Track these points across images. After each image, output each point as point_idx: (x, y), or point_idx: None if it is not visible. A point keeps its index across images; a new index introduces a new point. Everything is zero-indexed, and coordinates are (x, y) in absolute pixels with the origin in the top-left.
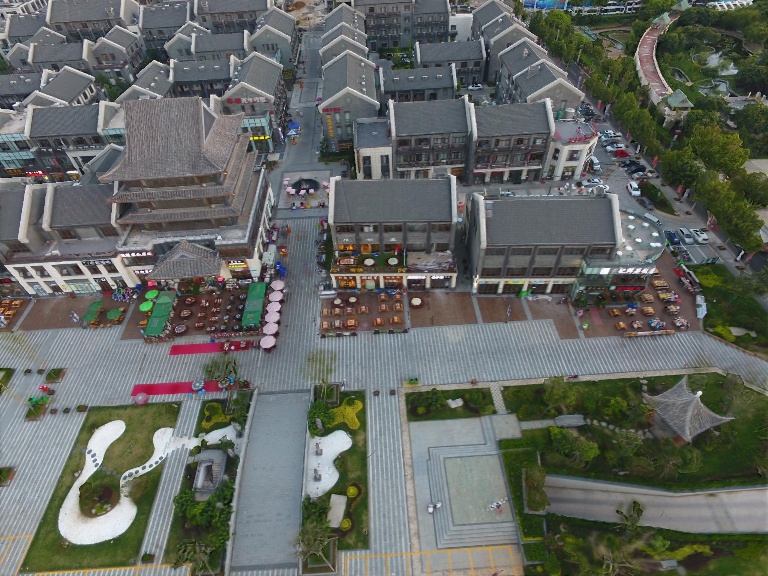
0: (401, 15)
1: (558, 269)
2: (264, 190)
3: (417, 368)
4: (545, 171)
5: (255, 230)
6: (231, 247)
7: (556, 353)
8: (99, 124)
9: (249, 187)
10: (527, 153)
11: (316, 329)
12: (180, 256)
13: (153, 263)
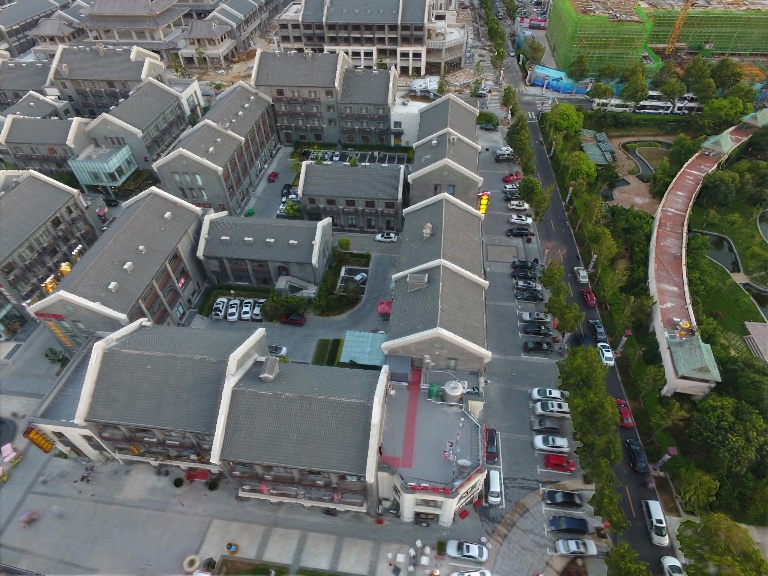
0: (322, 102)
1: None
2: None
3: None
4: (388, 498)
5: None
6: None
7: None
8: None
9: None
10: None
11: None
12: None
13: None
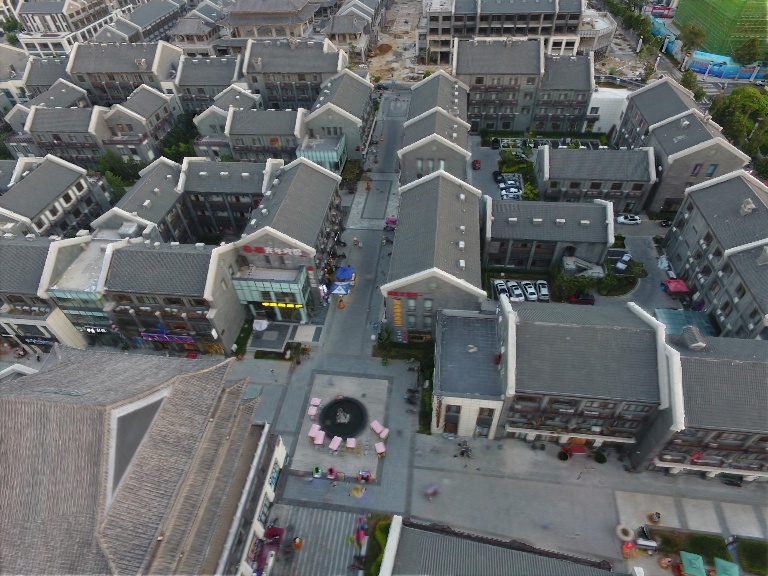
0: (521, 90)
1: None
2: (263, 468)
3: None
4: None
5: None
6: None
7: None
8: (42, 282)
9: None
10: None
11: None
12: None
13: None
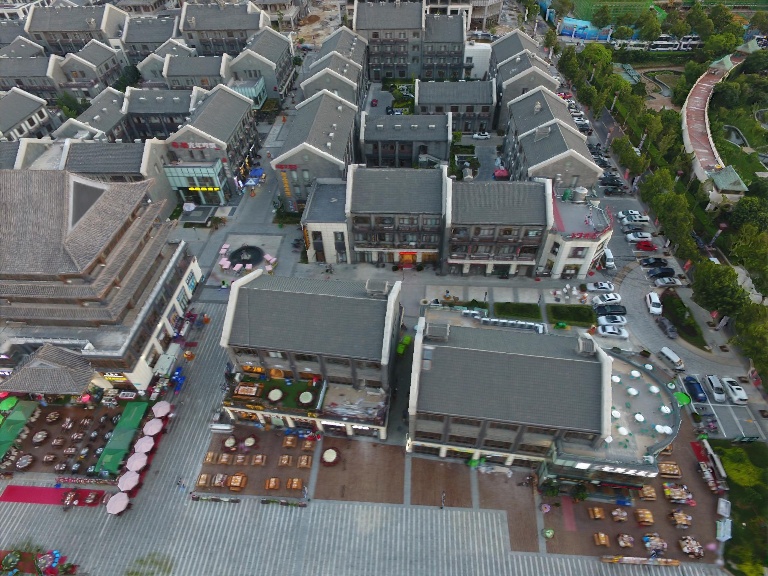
0: (409, 42)
1: (520, 445)
2: (181, 269)
3: (302, 573)
4: (541, 265)
5: (147, 331)
6: (103, 359)
7: (500, 575)
8: (16, 166)
9: (158, 267)
10: (516, 246)
11: (191, 483)
12: (40, 364)
13: (13, 365)
